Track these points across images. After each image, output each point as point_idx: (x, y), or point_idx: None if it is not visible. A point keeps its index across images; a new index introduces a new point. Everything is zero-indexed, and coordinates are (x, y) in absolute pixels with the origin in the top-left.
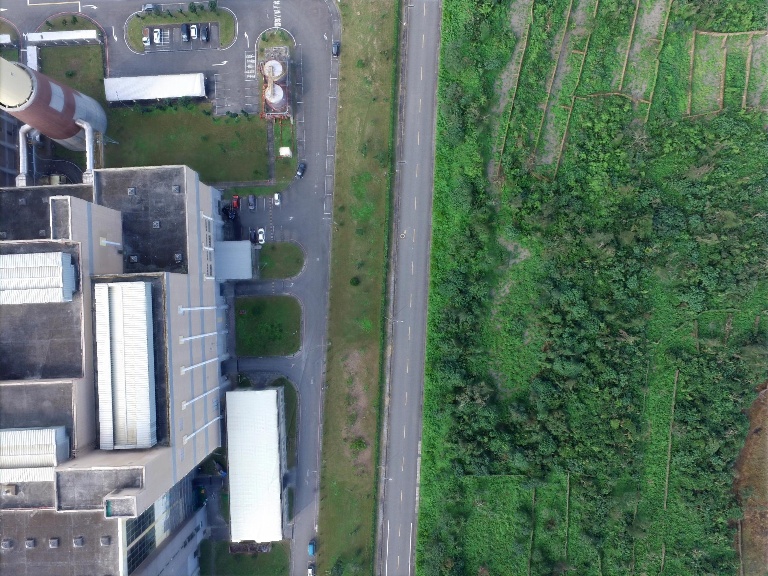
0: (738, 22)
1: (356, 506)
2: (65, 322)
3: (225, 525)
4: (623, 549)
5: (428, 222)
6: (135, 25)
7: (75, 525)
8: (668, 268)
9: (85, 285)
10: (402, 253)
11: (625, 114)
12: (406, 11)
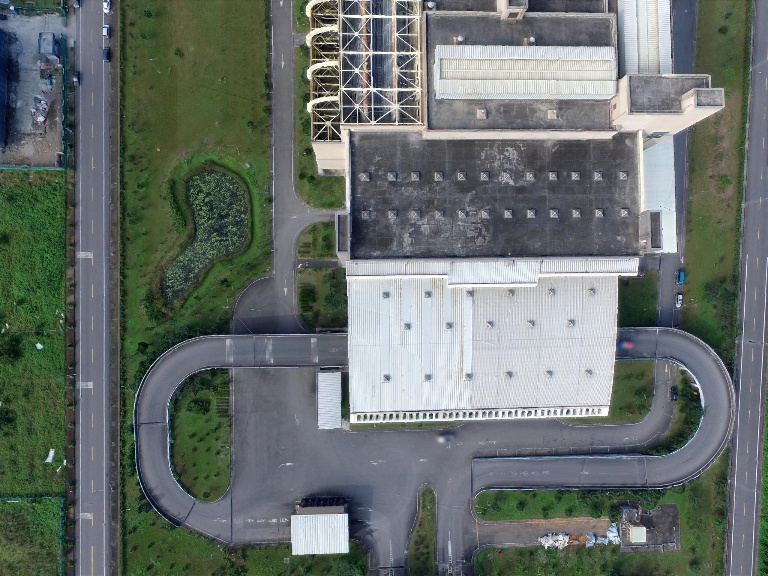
0: None
1: (720, 239)
2: None
3: None
4: None
5: None
6: None
7: (594, 160)
8: None
9: None
10: (760, 10)
11: None
12: None
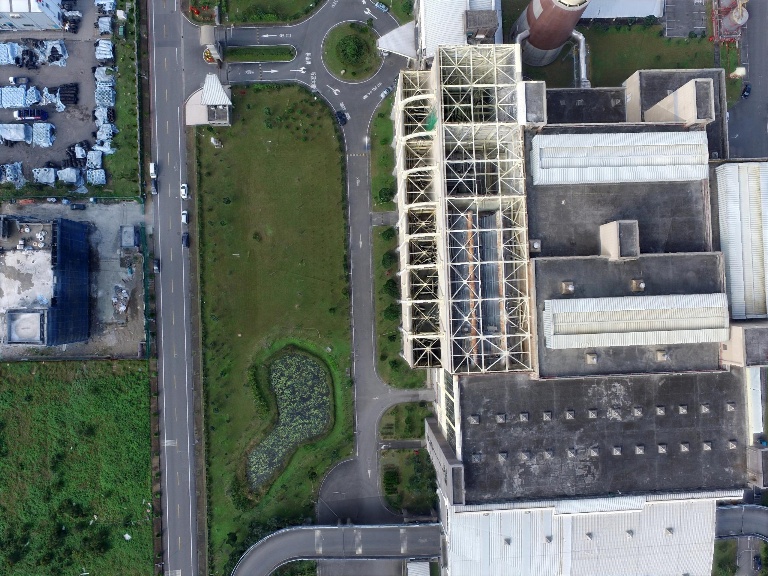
0: None
1: None
2: (685, 201)
3: None
4: None
5: None
6: None
7: (701, 392)
8: None
9: None
10: None
11: None
12: None
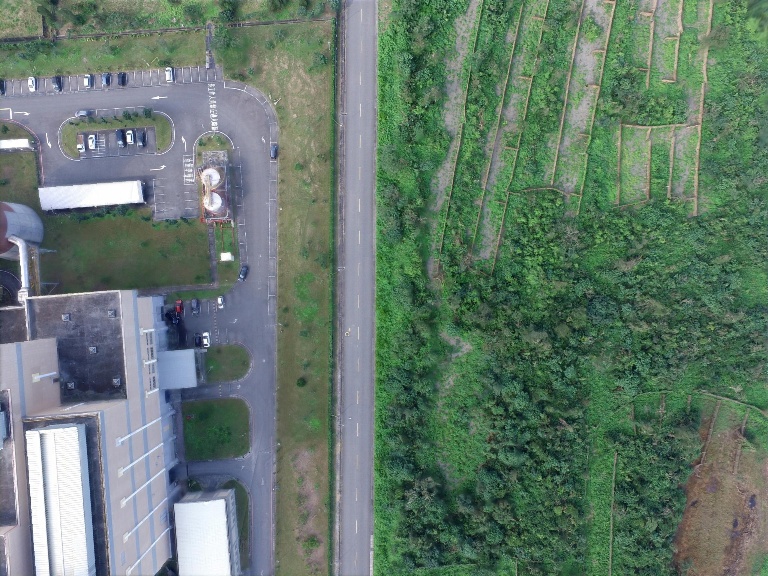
0: (660, 116)
1: None
2: None
3: None
4: None
5: (372, 319)
6: (69, 131)
7: None
8: (603, 357)
9: (16, 431)
10: (347, 351)
11: (557, 209)
12: (342, 112)
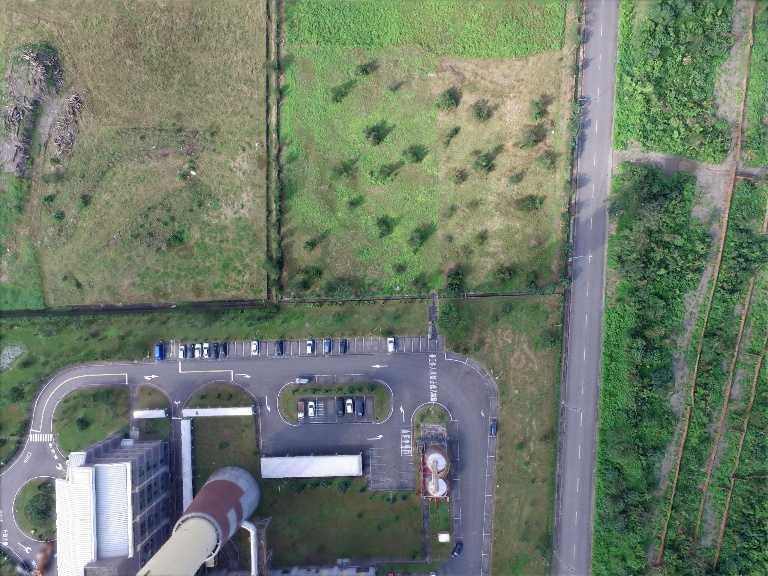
0: None
1: None
2: None
3: None
4: None
5: None
6: (289, 396)
7: None
8: None
9: None
10: None
11: None
12: (564, 389)
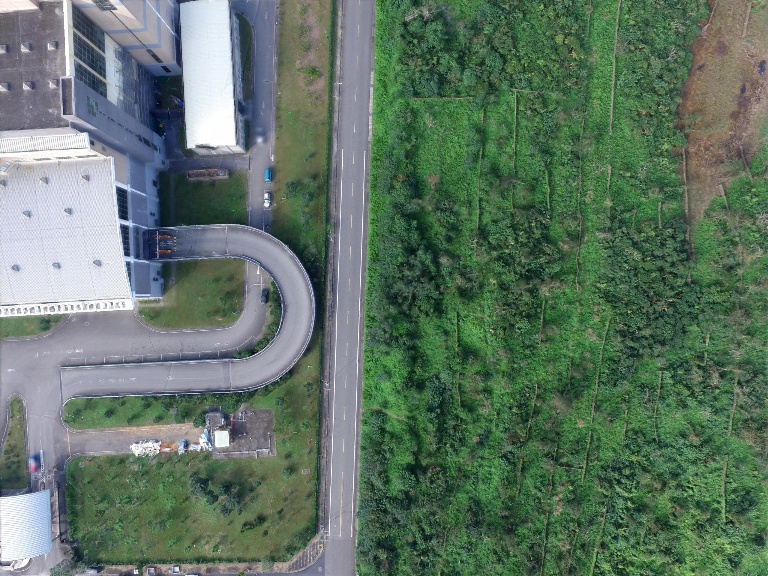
0: None
1: (311, 134)
2: None
3: (183, 158)
4: (570, 167)
5: None
6: None
7: (23, 33)
8: None
9: None
10: None
11: None
12: None
